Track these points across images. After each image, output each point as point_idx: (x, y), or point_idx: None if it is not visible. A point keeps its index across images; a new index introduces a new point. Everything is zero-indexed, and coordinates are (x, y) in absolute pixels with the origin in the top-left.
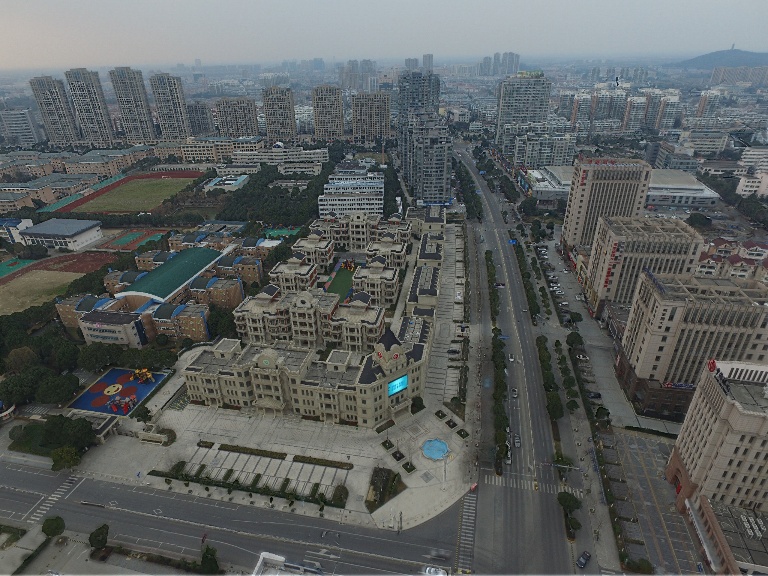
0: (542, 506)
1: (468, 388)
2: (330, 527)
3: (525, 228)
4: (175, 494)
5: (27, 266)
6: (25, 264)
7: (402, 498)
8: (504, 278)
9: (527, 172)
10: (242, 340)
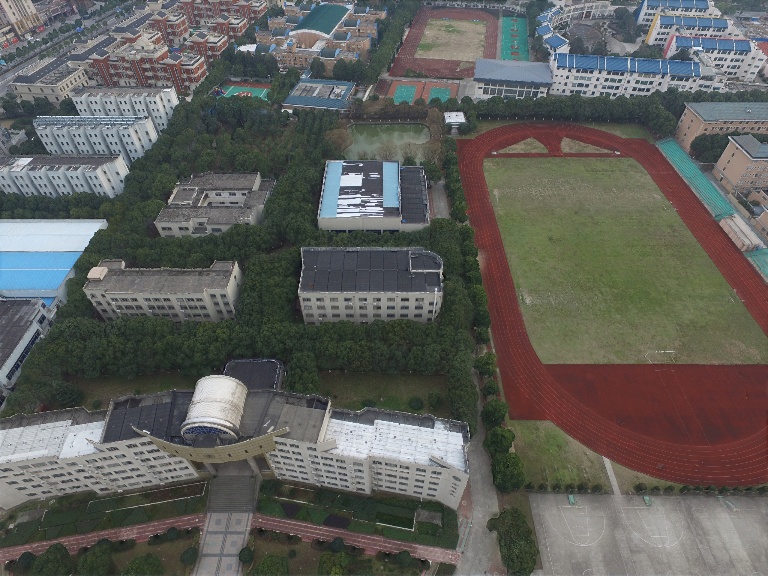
0: None
1: None
2: None
3: None
4: None
5: None
6: None
7: None
8: None
9: None
10: None
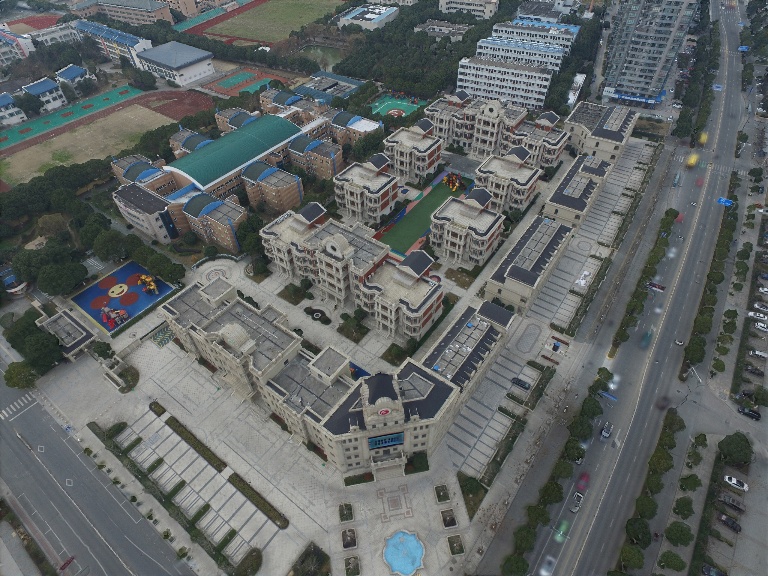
0: None
1: (508, 461)
2: None
3: (766, 174)
4: (95, 466)
5: (133, 98)
6: (132, 95)
7: None
8: (676, 266)
9: None
10: (270, 265)
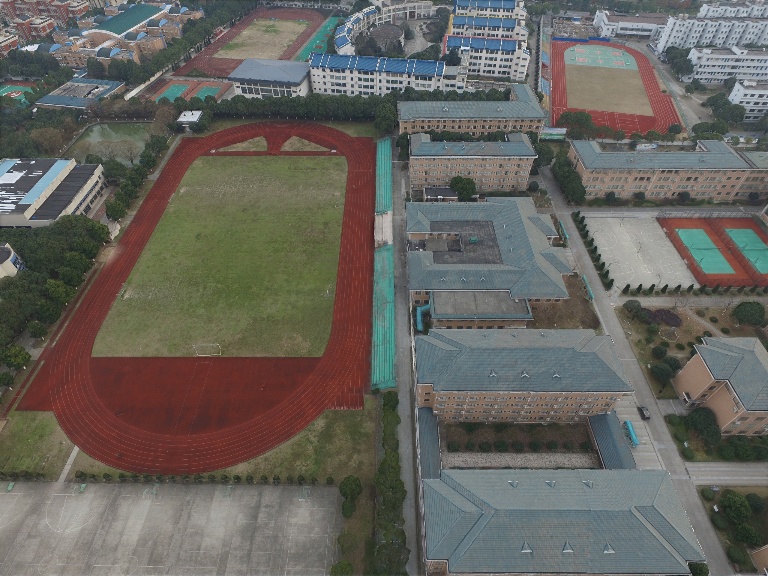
0: None
1: None
2: None
3: None
4: None
5: None
6: None
7: None
8: None
9: None
10: None
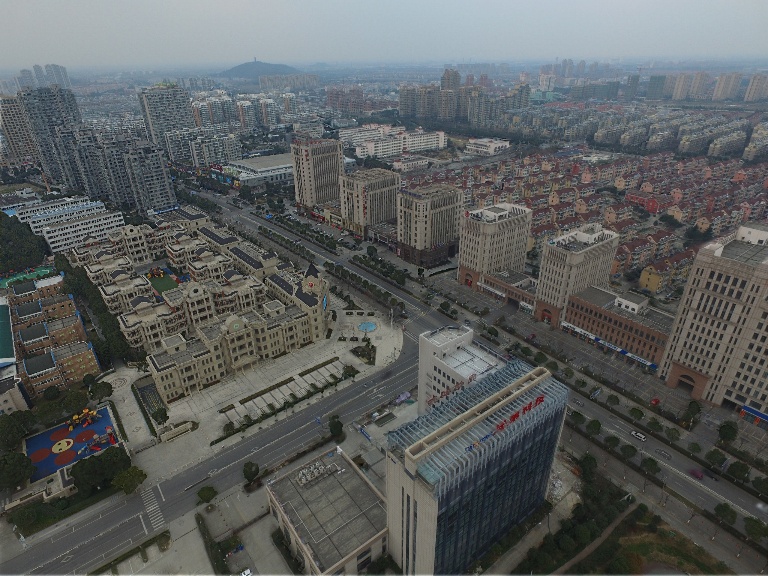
0: (435, 318)
1: None
2: (364, 382)
3: None
4: (251, 437)
5: None
6: None
7: (380, 351)
8: None
9: (223, 168)
10: None
